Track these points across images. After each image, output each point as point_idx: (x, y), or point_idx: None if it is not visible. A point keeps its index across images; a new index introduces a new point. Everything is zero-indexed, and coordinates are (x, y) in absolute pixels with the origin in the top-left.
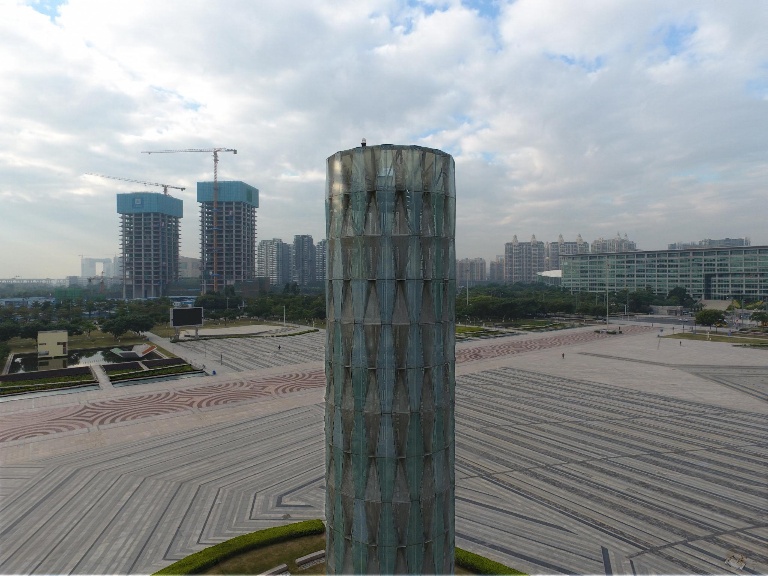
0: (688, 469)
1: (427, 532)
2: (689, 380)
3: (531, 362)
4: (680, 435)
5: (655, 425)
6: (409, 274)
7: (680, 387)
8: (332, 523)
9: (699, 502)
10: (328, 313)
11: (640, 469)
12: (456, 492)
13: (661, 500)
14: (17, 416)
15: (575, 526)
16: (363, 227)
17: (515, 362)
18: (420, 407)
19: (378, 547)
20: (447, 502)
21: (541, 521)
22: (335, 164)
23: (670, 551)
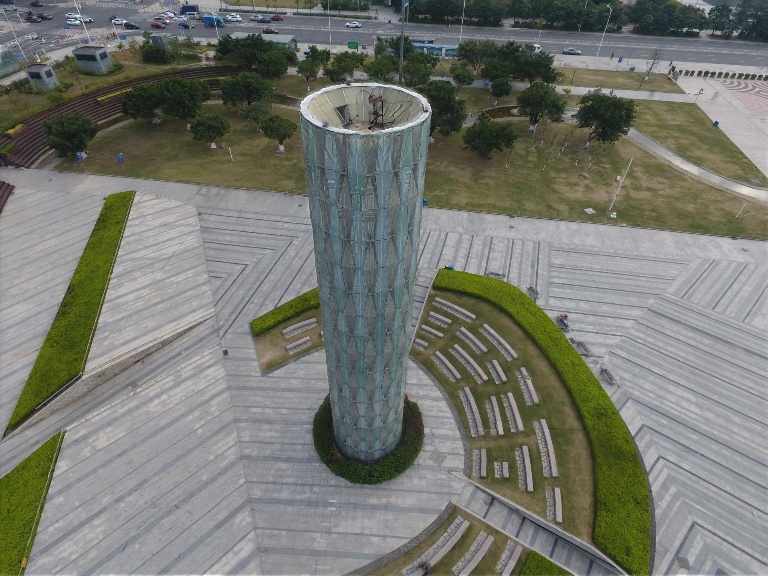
0: None
1: None
2: None
3: None
4: None
5: None
6: None
7: None
8: None
9: None
10: None
11: None
12: None
13: None
14: None
15: None
16: None
17: None
18: None
19: None
20: None
21: None
22: None
23: None
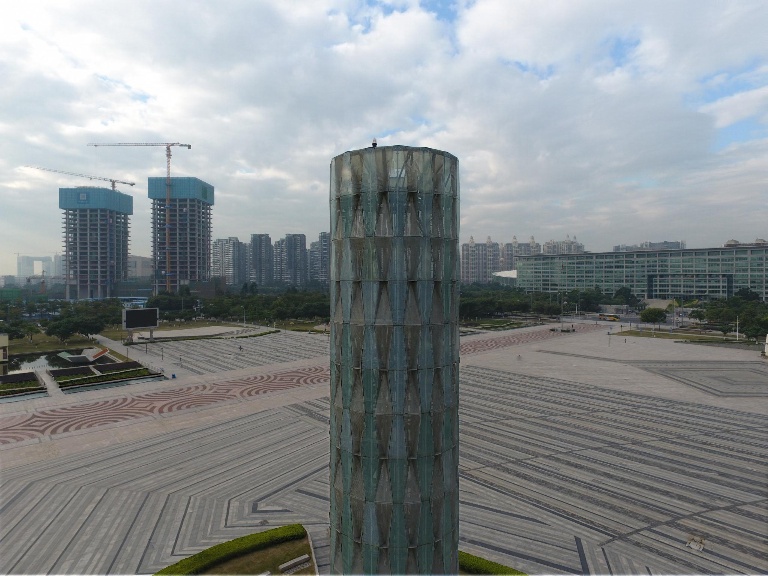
0: (646, 459)
1: (436, 531)
2: (639, 375)
3: (493, 360)
4: (636, 427)
5: (613, 418)
6: (420, 275)
7: (632, 382)
8: (339, 527)
9: (658, 490)
10: (334, 314)
11: (603, 460)
12: None
13: (624, 489)
14: None
15: (548, 518)
16: (374, 228)
17: (478, 360)
18: (430, 407)
19: (389, 549)
20: (454, 501)
21: (516, 515)
22: (343, 164)
23: (637, 537)
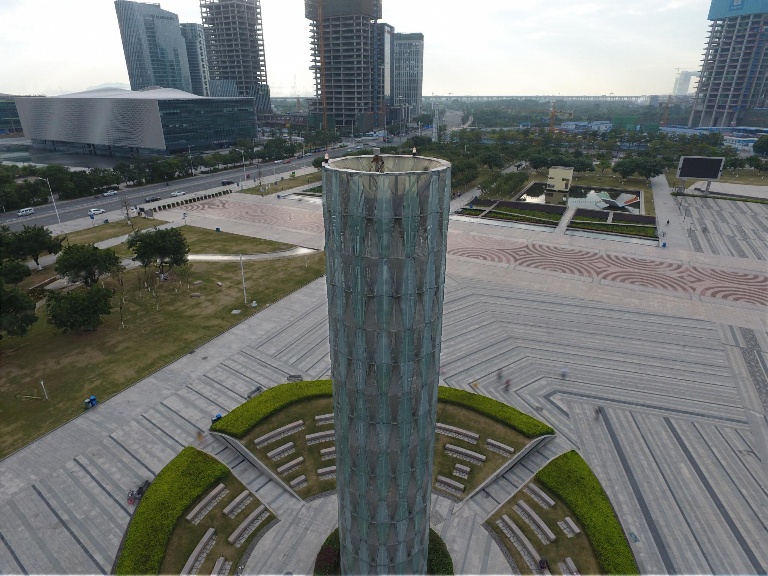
0: None
1: None
2: None
3: None
4: None
5: None
6: (337, 282)
7: None
8: None
9: None
10: None
11: None
12: (743, 522)
13: None
14: (485, 239)
15: None
16: None
17: None
18: (346, 382)
19: None
20: (376, 459)
21: None
22: None
23: None
